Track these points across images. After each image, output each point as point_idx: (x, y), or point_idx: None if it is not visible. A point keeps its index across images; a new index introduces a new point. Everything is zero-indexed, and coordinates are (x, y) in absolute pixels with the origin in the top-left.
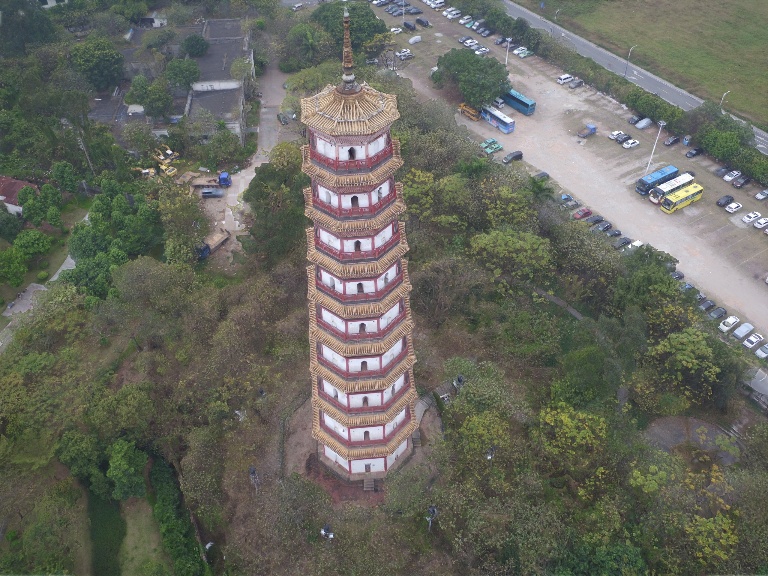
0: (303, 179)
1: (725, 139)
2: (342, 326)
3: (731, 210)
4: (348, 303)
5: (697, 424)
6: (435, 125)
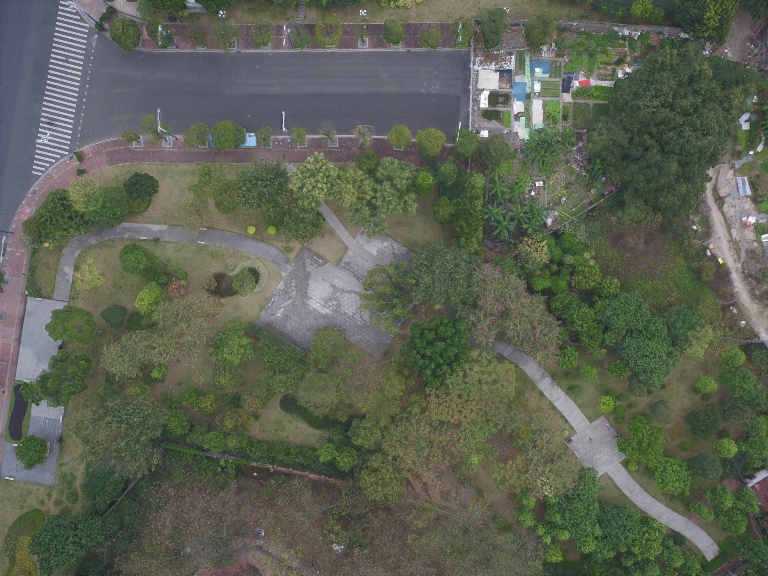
0: None
1: None
2: None
3: None
4: None
5: None
6: None
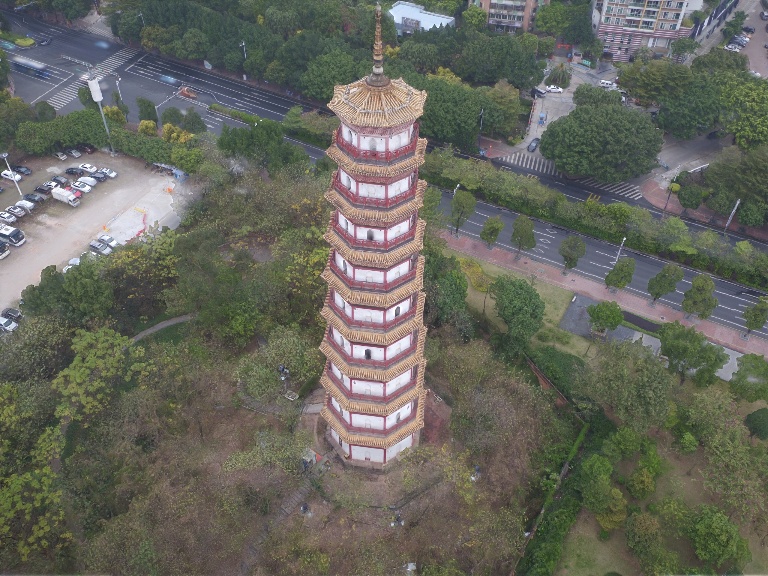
0: None
1: None
2: None
3: None
4: None
5: None
6: None
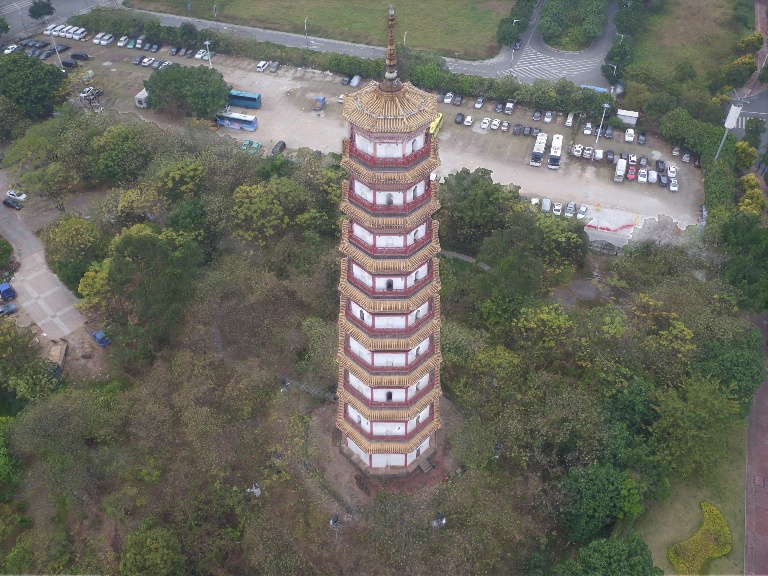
0: None
1: (430, 70)
2: (401, 323)
3: (469, 123)
4: (412, 295)
5: (572, 284)
6: (201, 145)
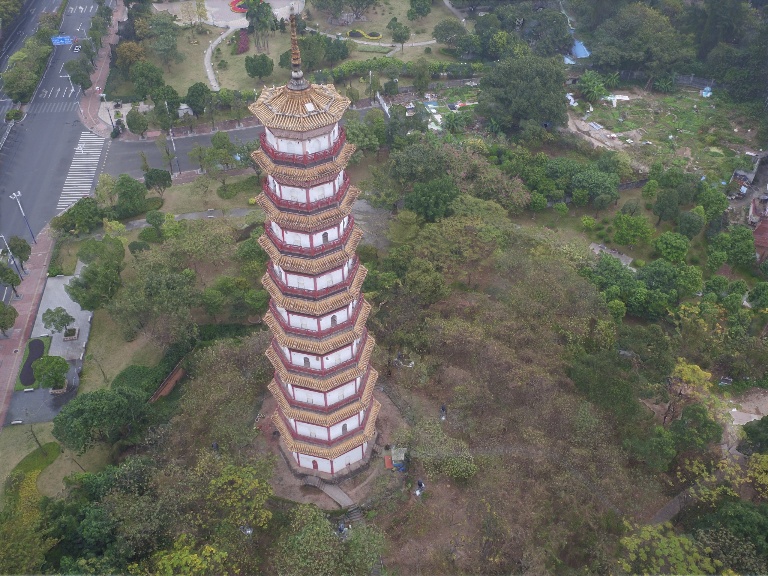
0: (691, 408)
1: None
2: None
3: None
4: None
5: None
6: None
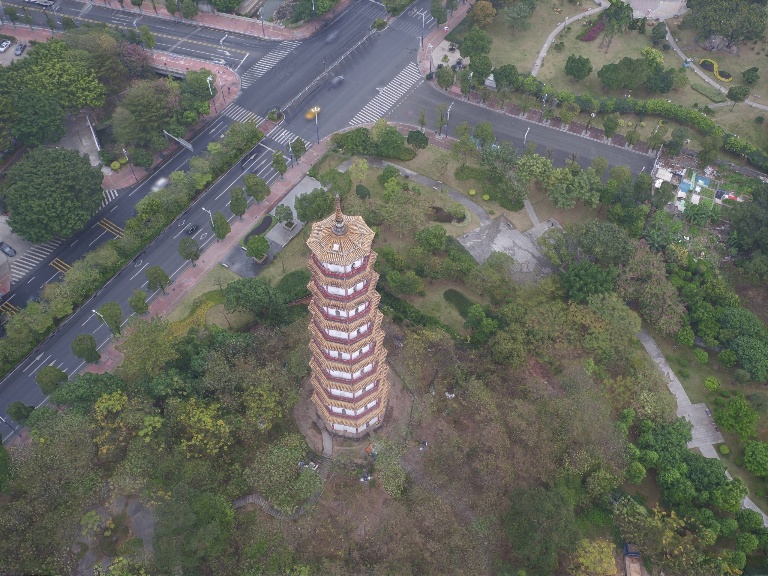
0: None
1: None
2: None
3: None
4: None
5: None
6: None
